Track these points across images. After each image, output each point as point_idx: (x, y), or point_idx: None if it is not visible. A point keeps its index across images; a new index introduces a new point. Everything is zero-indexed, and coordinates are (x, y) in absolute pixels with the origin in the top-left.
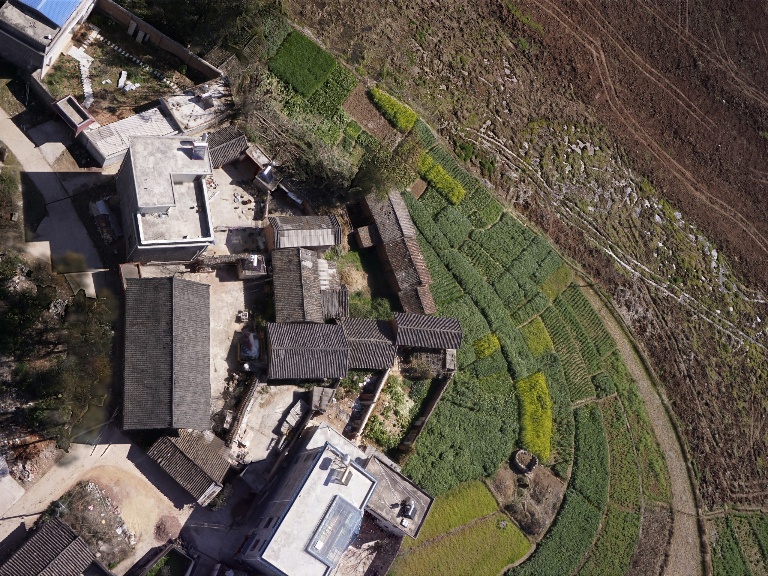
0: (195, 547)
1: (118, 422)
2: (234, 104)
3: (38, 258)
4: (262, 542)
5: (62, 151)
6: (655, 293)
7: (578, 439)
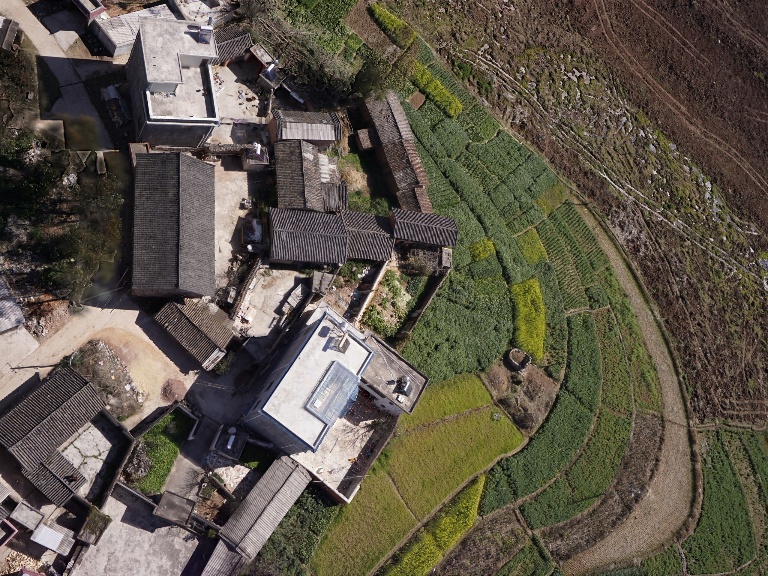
0: (200, 410)
1: (127, 289)
2: (239, 5)
3: (52, 135)
4: (263, 400)
5: (75, 39)
6: (649, 217)
7: (571, 344)
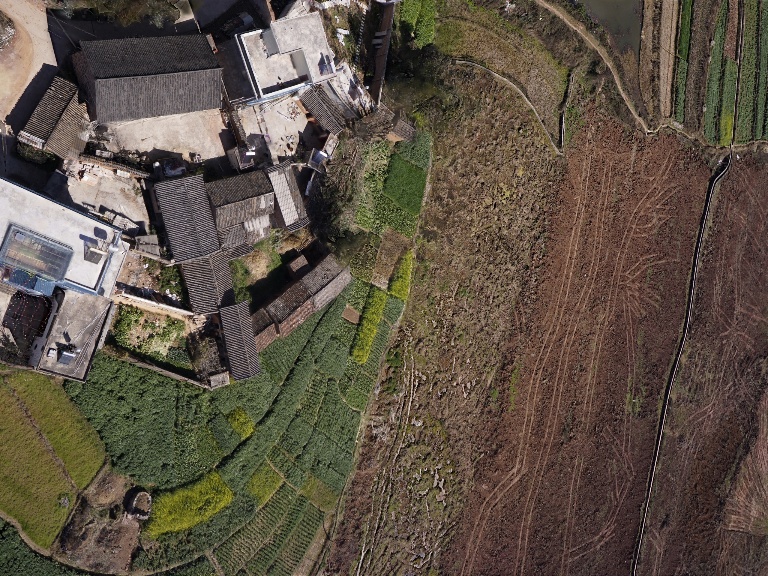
0: None
1: (75, 51)
2: None
3: None
4: None
5: None
6: None
7: (178, 571)
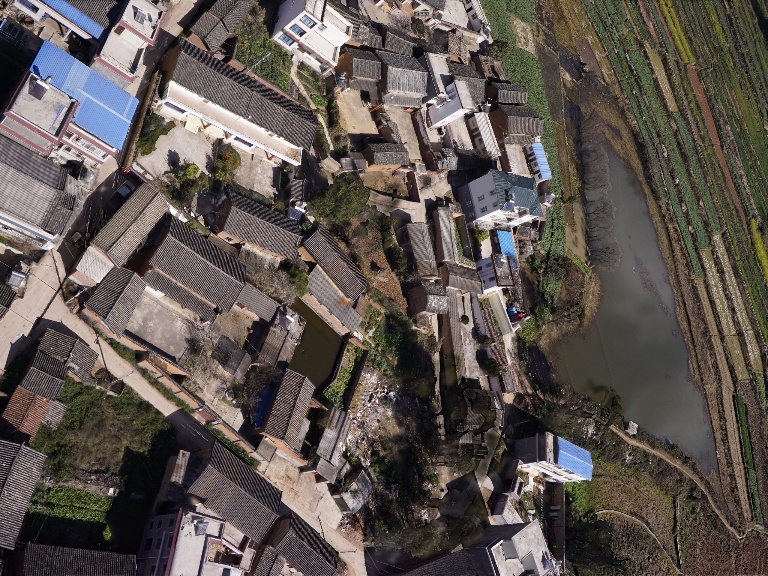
0: None
1: None
2: None
3: (441, 494)
4: None
5: (490, 489)
6: None
7: None
